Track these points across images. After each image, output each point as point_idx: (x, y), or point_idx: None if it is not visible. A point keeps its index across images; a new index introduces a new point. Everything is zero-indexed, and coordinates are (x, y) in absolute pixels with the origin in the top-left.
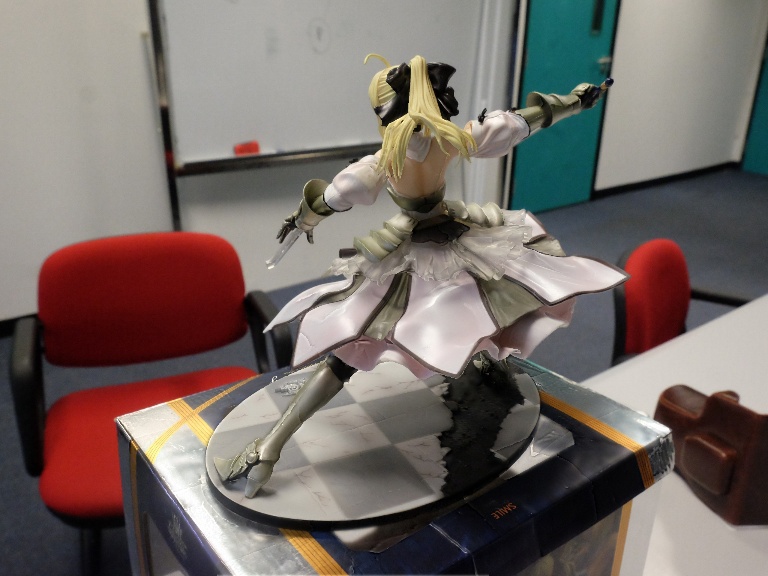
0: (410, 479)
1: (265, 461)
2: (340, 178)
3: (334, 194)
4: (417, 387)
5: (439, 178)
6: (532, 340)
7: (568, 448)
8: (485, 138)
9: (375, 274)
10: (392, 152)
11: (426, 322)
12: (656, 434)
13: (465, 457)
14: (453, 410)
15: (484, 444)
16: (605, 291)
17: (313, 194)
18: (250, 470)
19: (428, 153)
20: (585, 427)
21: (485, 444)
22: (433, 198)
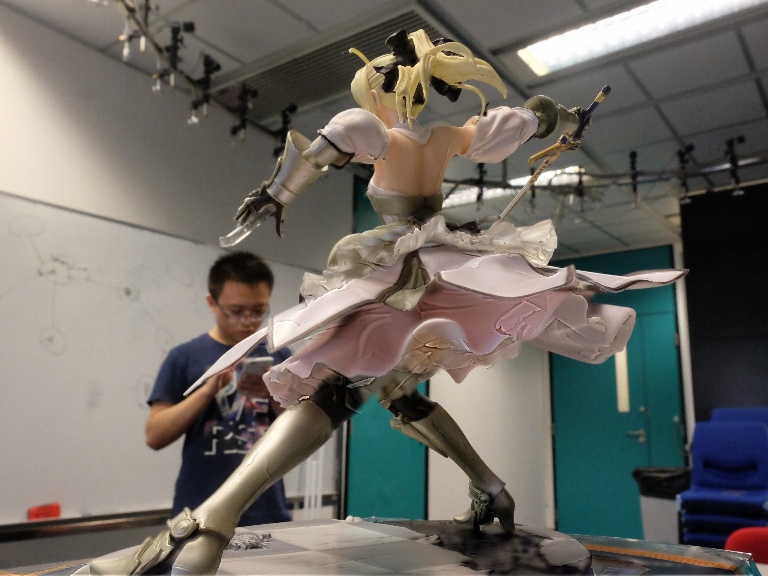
0: None
1: (210, 533)
2: (341, 115)
3: (335, 127)
4: (393, 540)
5: (439, 177)
6: (611, 321)
7: (647, 572)
8: (492, 127)
9: (381, 253)
10: (408, 86)
11: (480, 270)
12: (738, 559)
13: None
14: (460, 552)
15: (533, 568)
16: (668, 283)
17: (299, 145)
18: (179, 552)
19: (430, 137)
20: (647, 558)
21: (535, 568)
22: (433, 201)
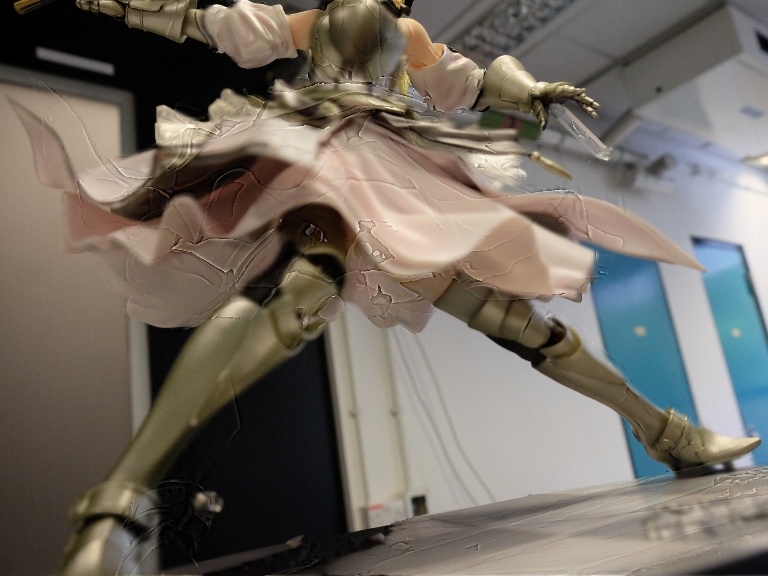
0: (466, 522)
1: None
2: None
3: None
4: None
5: None
6: None
7: None
8: None
9: None
10: None
11: None
12: None
13: (369, 561)
14: None
15: (322, 572)
16: None
17: None
18: None
19: None
20: None
21: (320, 572)
22: None
